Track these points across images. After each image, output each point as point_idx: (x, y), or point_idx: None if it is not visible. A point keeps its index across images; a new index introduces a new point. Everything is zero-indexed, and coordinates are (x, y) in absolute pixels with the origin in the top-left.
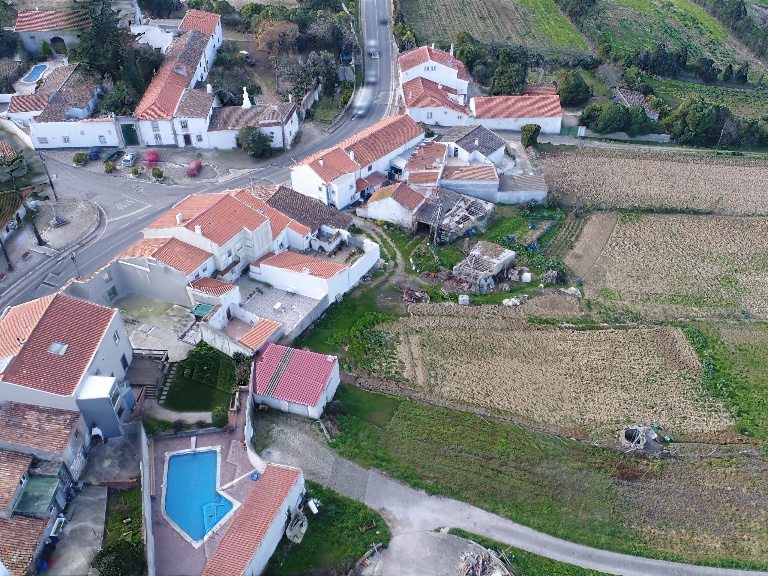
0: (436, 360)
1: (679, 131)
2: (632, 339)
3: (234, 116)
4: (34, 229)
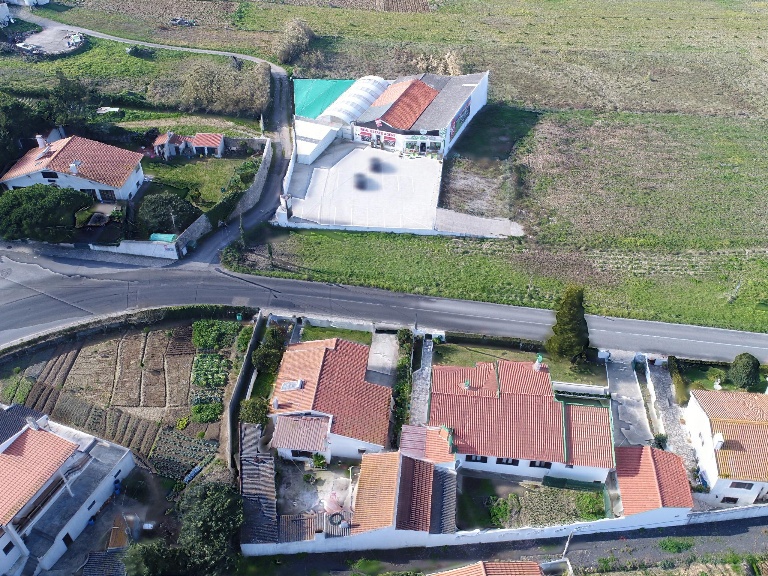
0: (102, 1)
1: None
2: (210, 3)
3: None
4: None
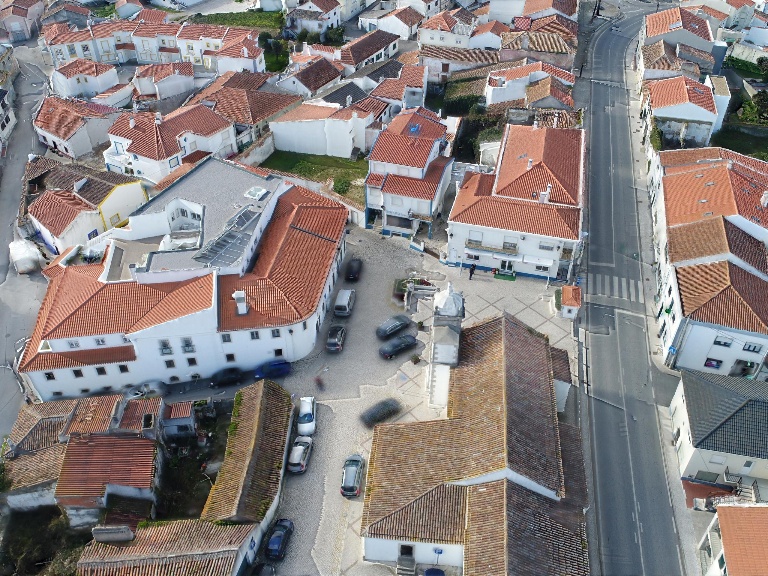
0: None
1: None
2: None
3: None
4: (599, 4)
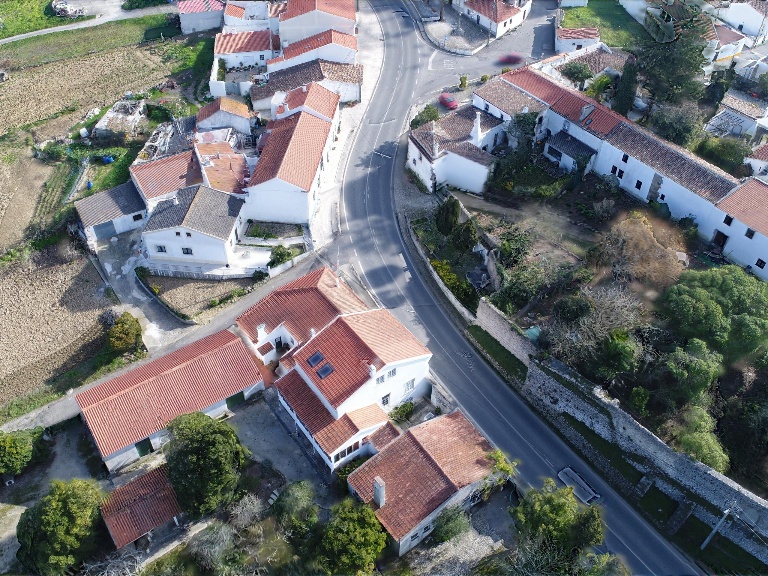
0: None
1: None
2: None
3: (472, 122)
4: None
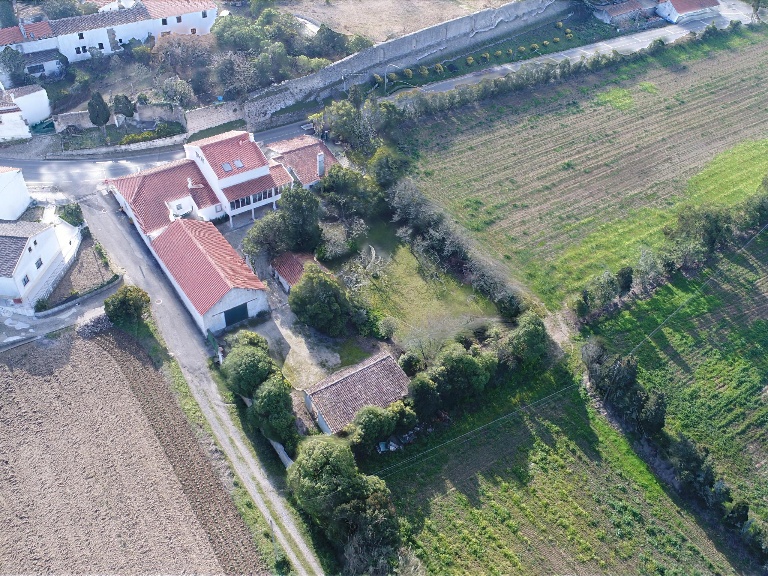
0: None
1: None
2: None
3: None
4: None
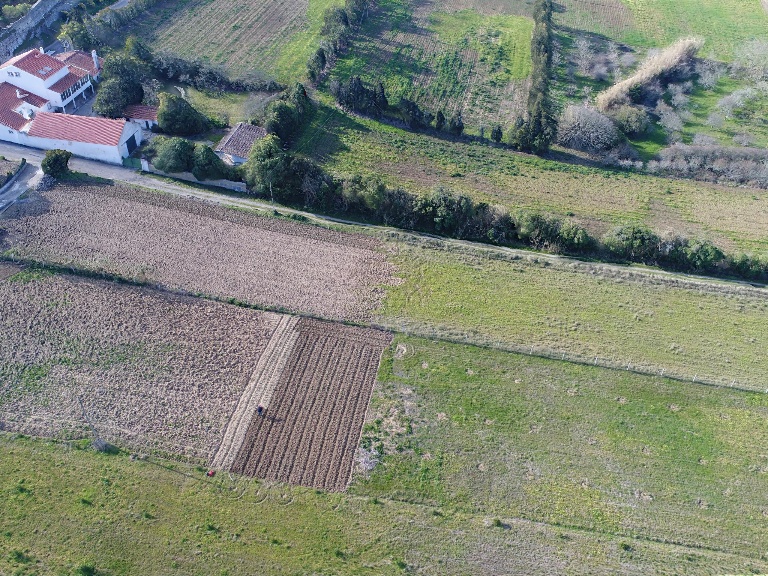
0: None
1: (250, 181)
2: None
3: None
4: None
